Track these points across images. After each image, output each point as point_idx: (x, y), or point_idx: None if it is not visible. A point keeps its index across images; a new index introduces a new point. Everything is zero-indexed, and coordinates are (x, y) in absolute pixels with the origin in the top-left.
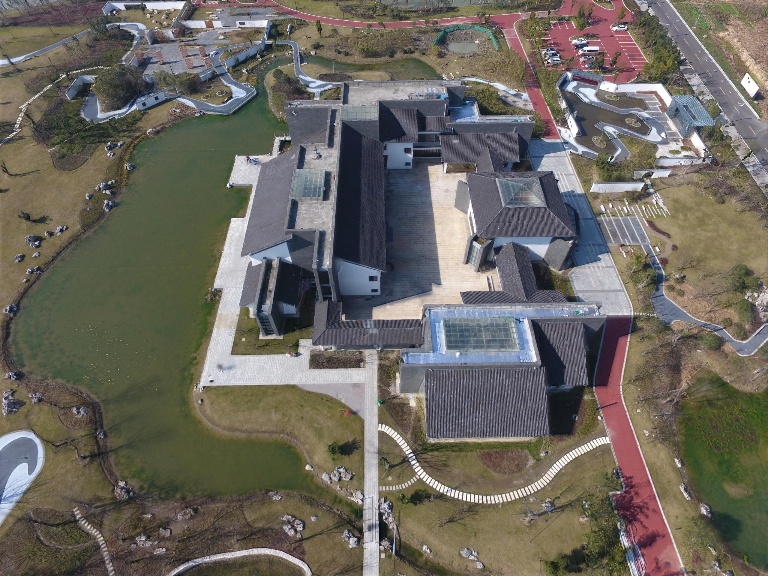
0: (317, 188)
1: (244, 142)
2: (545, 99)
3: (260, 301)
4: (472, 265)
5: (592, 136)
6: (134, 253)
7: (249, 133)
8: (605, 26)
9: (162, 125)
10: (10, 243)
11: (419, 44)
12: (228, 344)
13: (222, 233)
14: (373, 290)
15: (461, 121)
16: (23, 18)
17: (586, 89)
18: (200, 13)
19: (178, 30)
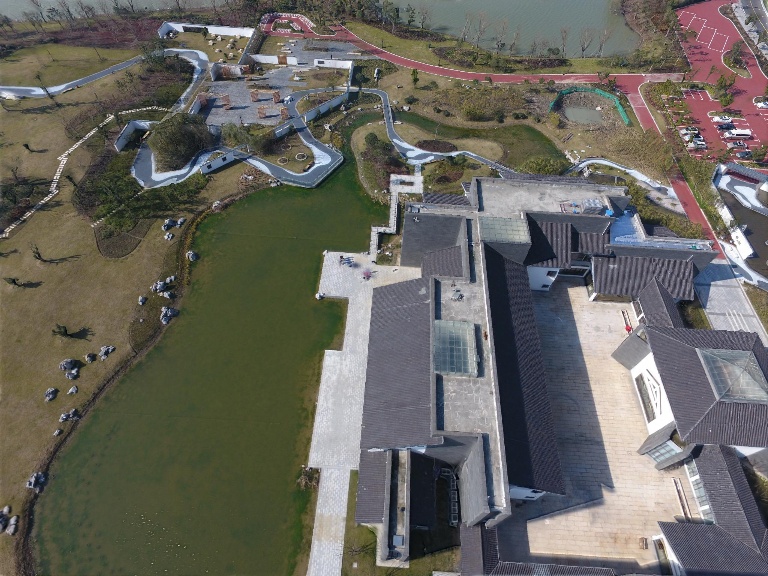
0: (468, 356)
1: (332, 229)
2: (696, 198)
3: (389, 526)
4: (651, 458)
5: (766, 259)
6: (200, 394)
7: (337, 216)
8: (747, 100)
9: (231, 197)
10: (39, 368)
11: (532, 107)
12: (334, 572)
13: (313, 371)
14: (529, 497)
15: (621, 240)
16: (65, 33)
17: (743, 188)
18: (270, 44)
19: (248, 67)
